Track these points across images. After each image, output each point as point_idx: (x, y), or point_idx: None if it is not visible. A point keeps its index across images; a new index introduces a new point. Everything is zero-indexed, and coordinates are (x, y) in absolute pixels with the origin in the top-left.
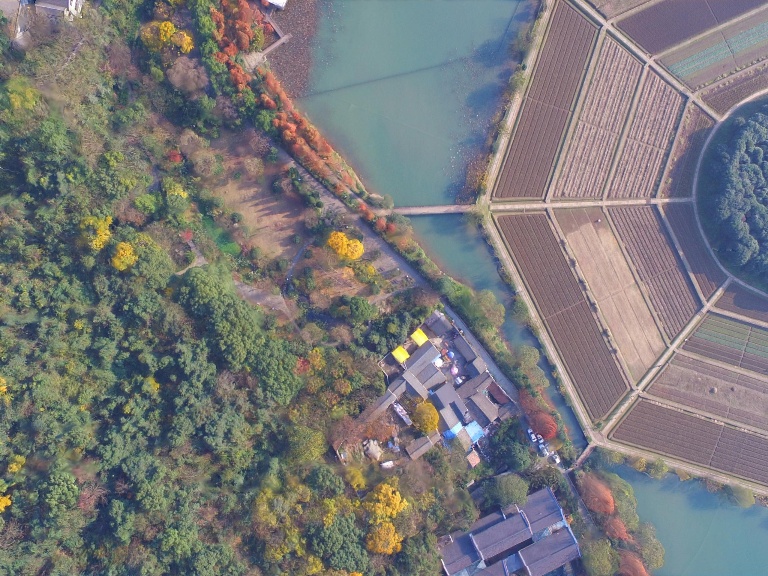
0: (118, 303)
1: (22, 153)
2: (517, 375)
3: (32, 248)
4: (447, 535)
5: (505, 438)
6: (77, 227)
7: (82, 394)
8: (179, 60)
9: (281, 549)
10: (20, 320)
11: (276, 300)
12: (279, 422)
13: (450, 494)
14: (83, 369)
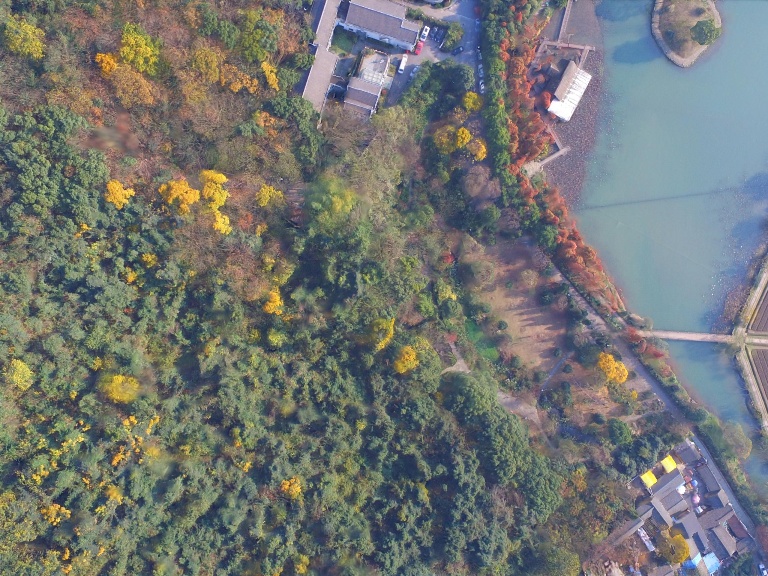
0: (391, 403)
1: (326, 251)
2: (758, 511)
3: (317, 342)
4: None
5: (740, 572)
6: (366, 327)
7: (359, 496)
8: (477, 170)
9: None
10: (310, 417)
11: (529, 410)
12: (535, 539)
13: None
14: (357, 468)
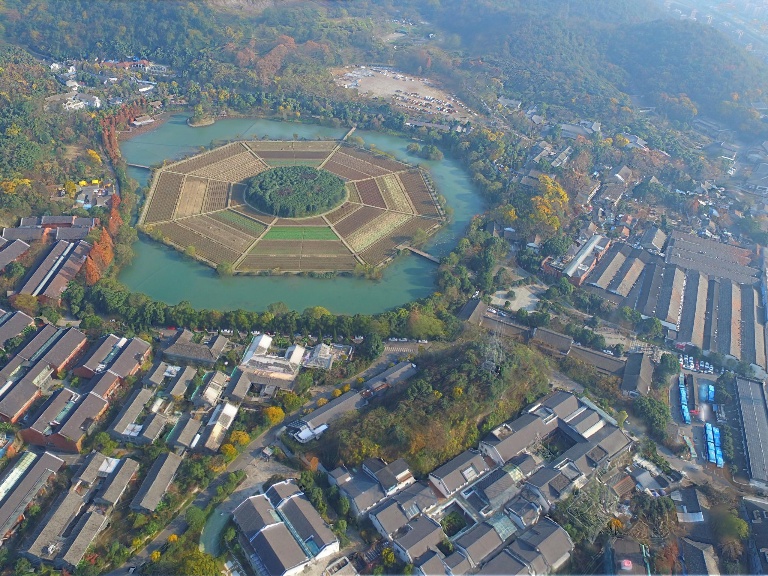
0: None
1: None
2: None
3: None
4: (36, 217)
5: None
6: None
7: None
8: None
9: None
10: None
11: None
12: None
13: None
14: None
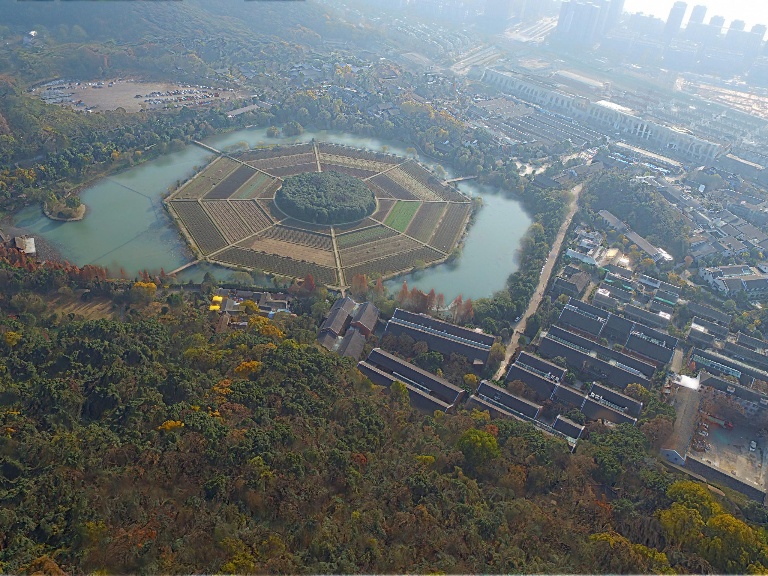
0: None
1: None
2: (280, 287)
3: None
4: None
5: None
6: None
7: None
8: None
9: None
10: None
11: None
12: None
13: None
14: None
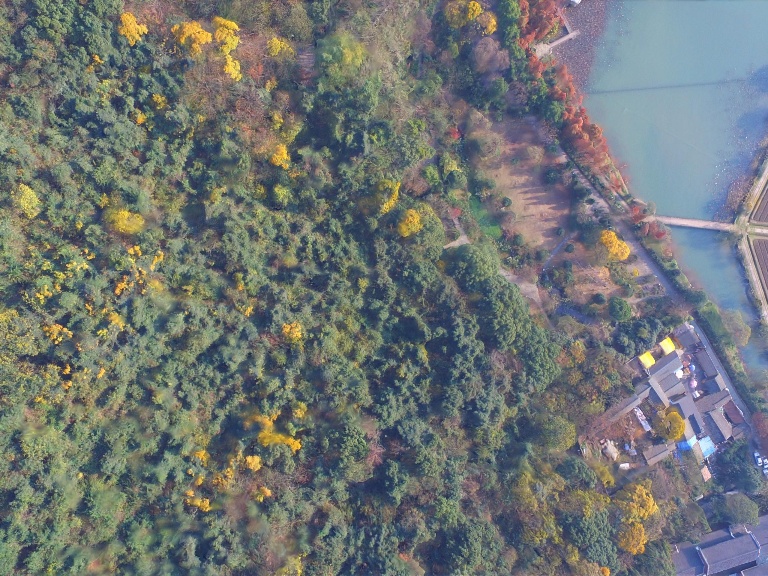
0: (393, 268)
1: (334, 108)
2: (754, 397)
3: (322, 202)
4: (674, 544)
5: (735, 458)
6: (372, 188)
7: (359, 352)
8: (487, 40)
9: (541, 533)
10: None
11: (530, 288)
12: (532, 408)
13: (686, 504)
14: (357, 327)
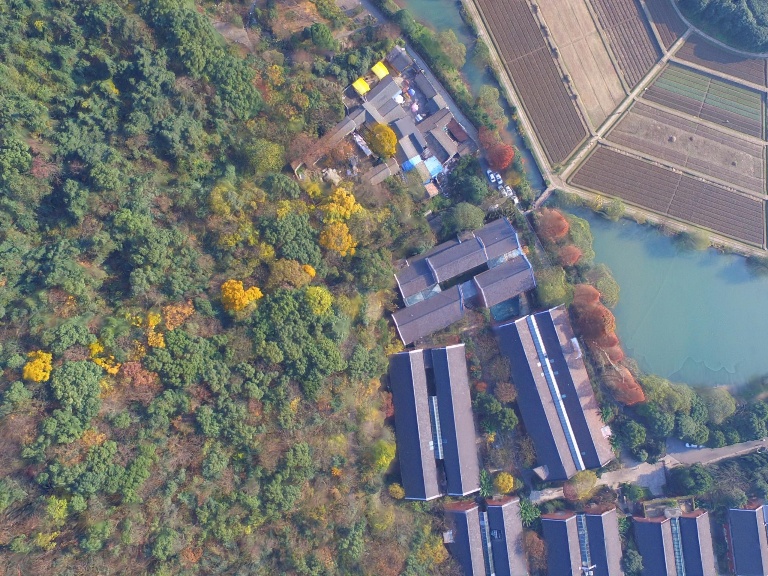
0: (80, 15)
1: None
2: (477, 113)
3: None
4: (403, 259)
5: (464, 174)
6: None
7: (41, 89)
8: None
9: (234, 236)
10: None
11: (239, 33)
12: (237, 136)
13: (406, 215)
14: (43, 71)
